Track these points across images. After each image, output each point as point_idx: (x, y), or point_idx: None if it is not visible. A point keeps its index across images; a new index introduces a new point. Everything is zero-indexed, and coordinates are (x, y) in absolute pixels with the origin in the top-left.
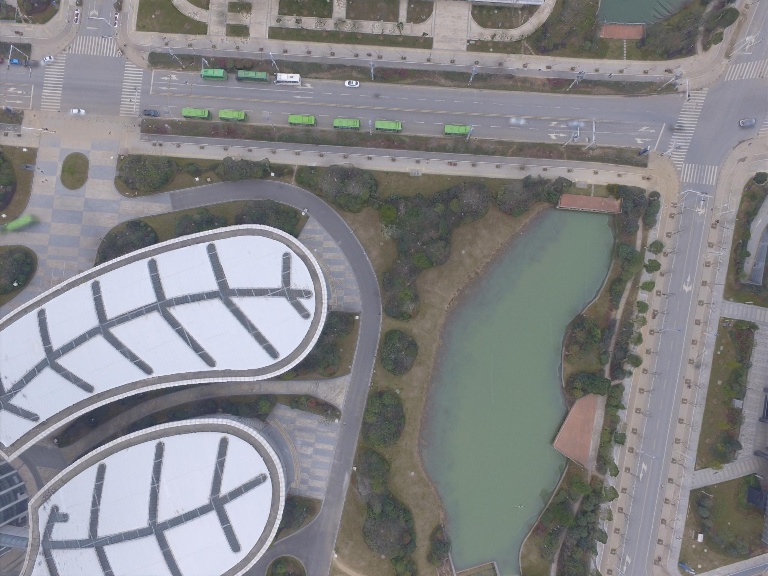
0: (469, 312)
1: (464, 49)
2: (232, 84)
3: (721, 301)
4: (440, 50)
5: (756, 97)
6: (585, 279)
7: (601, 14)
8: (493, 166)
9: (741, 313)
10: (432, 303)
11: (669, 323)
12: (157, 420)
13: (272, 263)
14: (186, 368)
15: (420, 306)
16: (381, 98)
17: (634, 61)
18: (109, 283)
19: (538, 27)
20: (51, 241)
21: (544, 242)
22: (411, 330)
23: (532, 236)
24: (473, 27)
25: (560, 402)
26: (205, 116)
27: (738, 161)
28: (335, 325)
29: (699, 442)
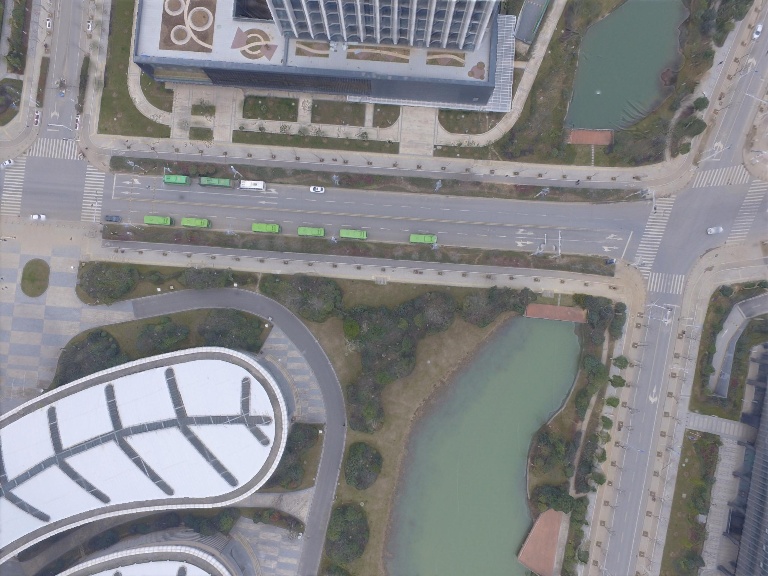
0: (435, 422)
1: (431, 154)
2: (195, 189)
3: (687, 413)
4: (406, 155)
5: (724, 205)
6: (553, 383)
7: (569, 120)
8: (459, 274)
9: (706, 425)
10: (397, 414)
11: (634, 435)
12: (119, 534)
13: (231, 389)
14: (144, 497)
15: (385, 418)
16: (347, 204)
17: (602, 167)
18: (65, 410)
19: (505, 132)
20: (11, 350)
21: (510, 350)
22: (376, 442)
23: (498, 344)
24: (440, 132)
25: (526, 509)
26: (167, 224)
27: (705, 270)
28: (299, 437)
29: (663, 555)
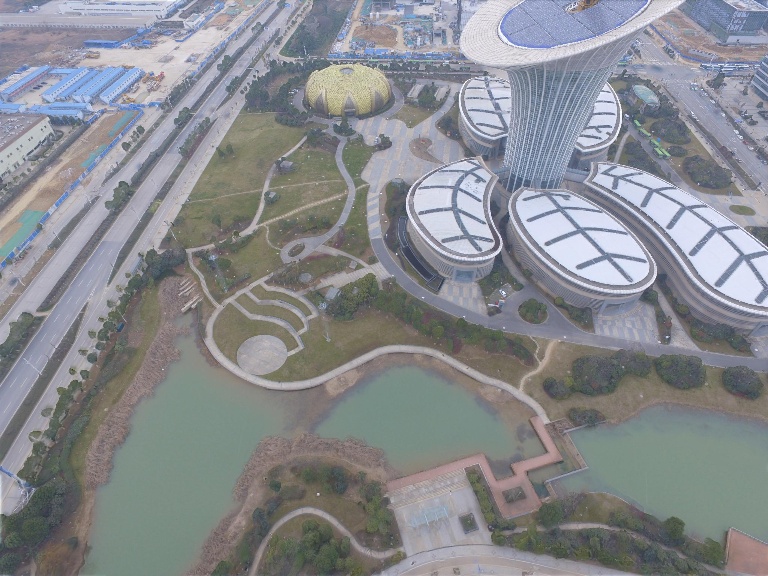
0: None
1: None
2: None
3: None
4: None
5: None
6: None
7: None
8: None
9: None
10: None
11: None
12: None
13: None
14: (681, 243)
15: None
16: None
17: None
18: (711, 211)
19: None
20: None
21: None
22: (766, 394)
23: None
24: None
25: None
26: None
27: None
28: None
29: None
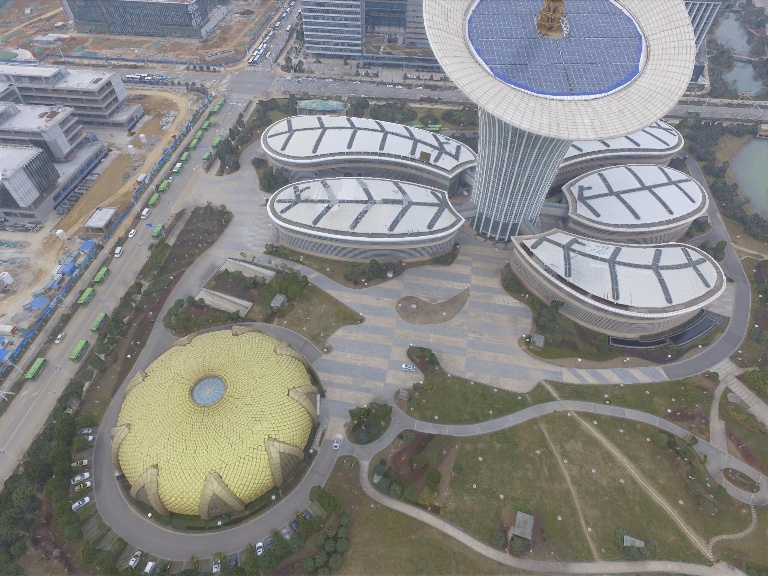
0: (739, 165)
1: None
2: None
3: None
4: None
5: None
6: None
7: None
8: None
9: None
10: (719, 159)
11: None
12: None
13: None
14: (626, 146)
15: None
16: None
17: (758, 101)
18: None
19: None
20: None
21: (759, 146)
22: None
23: (752, 144)
24: None
25: None
26: None
27: None
28: None
29: None
